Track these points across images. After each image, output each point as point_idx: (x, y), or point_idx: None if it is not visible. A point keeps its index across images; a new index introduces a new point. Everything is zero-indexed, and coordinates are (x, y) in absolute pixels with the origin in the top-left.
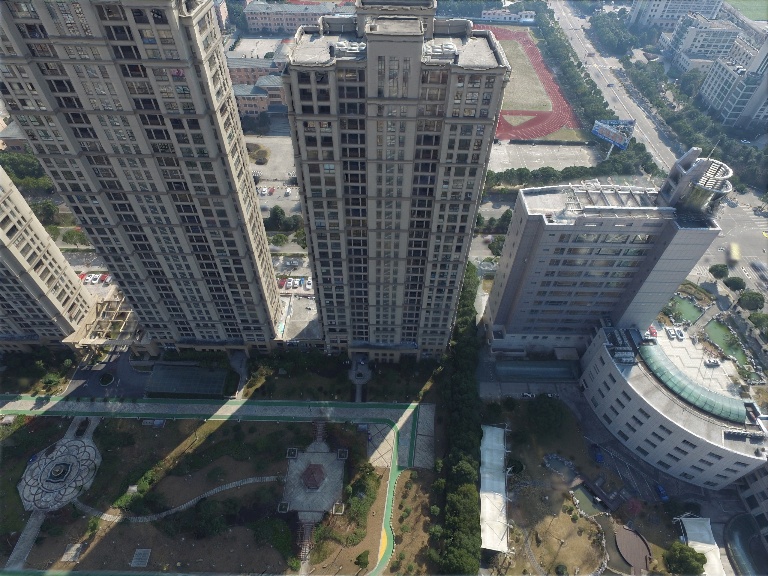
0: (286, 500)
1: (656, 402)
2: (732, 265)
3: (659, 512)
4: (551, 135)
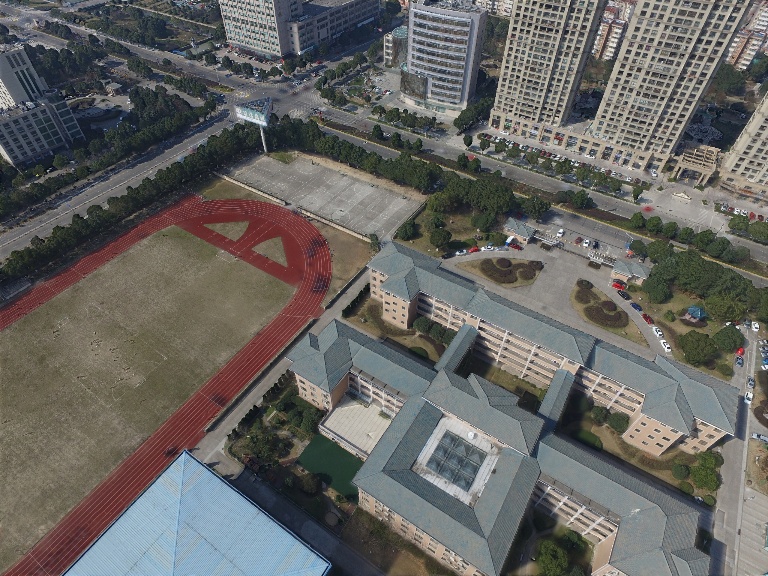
0: (596, 101)
1: None
2: None
3: None
4: (234, 197)
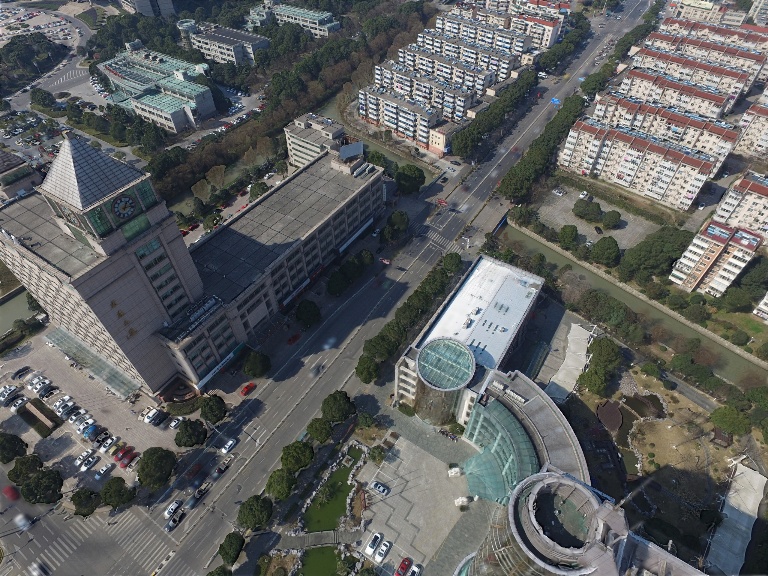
0: None
1: (567, 458)
2: None
3: (571, 420)
4: None
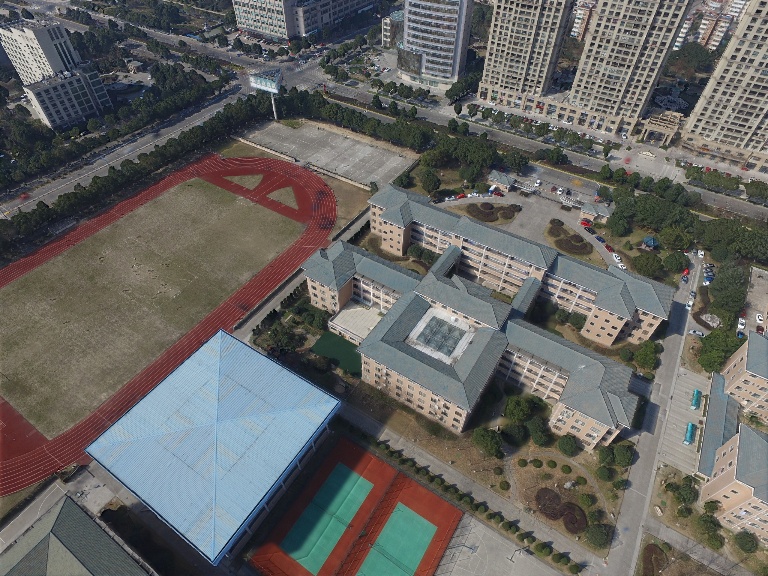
0: None
1: None
2: (302, 72)
3: None
4: (249, 155)
